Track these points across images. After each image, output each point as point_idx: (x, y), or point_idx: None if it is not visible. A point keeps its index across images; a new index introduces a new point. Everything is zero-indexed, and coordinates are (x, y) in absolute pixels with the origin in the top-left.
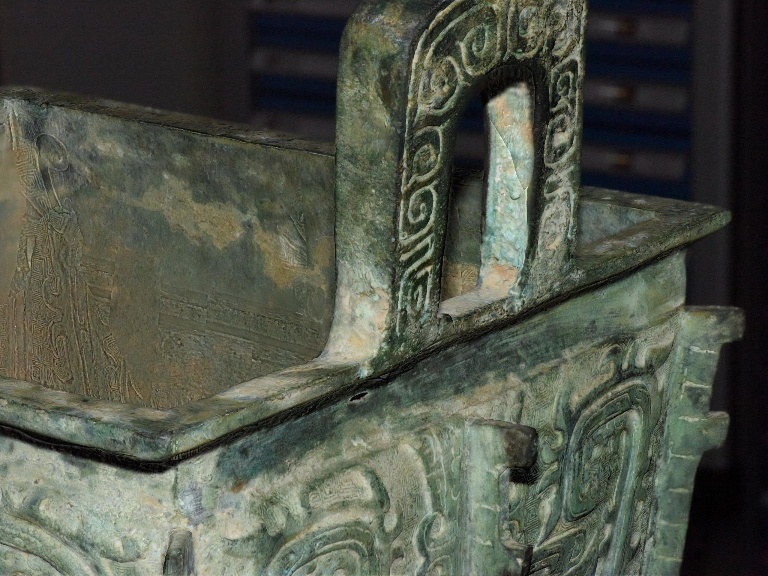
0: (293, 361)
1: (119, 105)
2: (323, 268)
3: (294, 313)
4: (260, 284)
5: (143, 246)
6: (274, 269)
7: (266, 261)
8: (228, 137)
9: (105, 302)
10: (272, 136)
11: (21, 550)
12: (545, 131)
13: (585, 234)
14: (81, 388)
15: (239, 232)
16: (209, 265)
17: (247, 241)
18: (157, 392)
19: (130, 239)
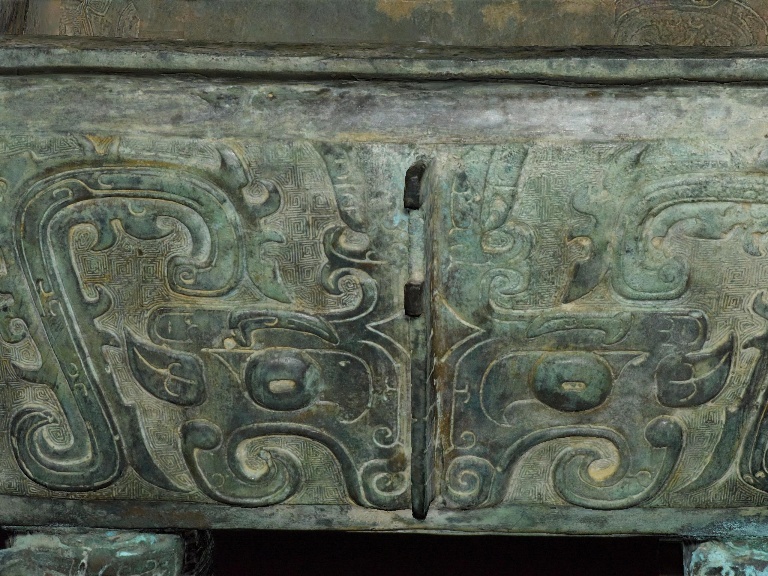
0: None
1: None
2: None
3: (416, 42)
4: (372, 22)
5: (220, 10)
6: (389, 5)
7: None
8: None
9: None
10: None
11: (750, 202)
12: None
13: None
14: None
15: None
16: (306, 14)
17: None
18: None
19: (202, 6)
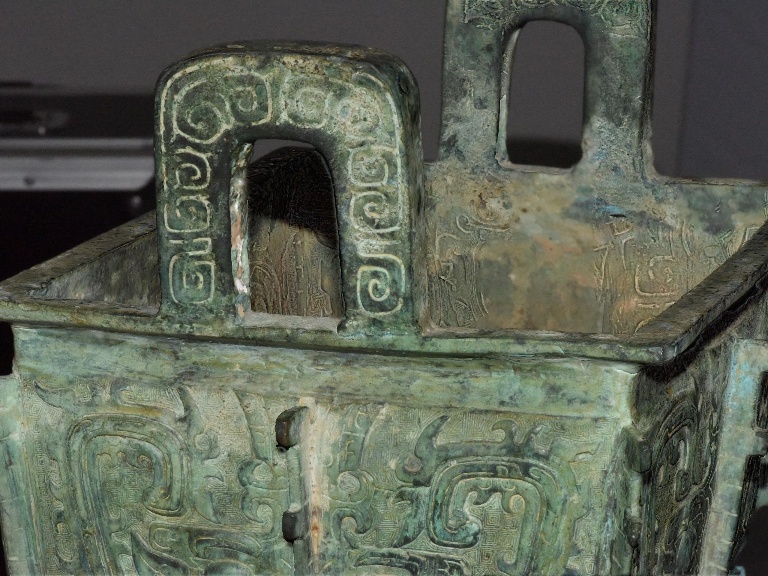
0: None
1: (45, 265)
2: None
3: None
4: None
5: None
6: None
7: None
8: None
9: None
10: (133, 227)
11: None
12: (505, 58)
13: None
14: None
15: None
16: None
17: None
18: None
19: None
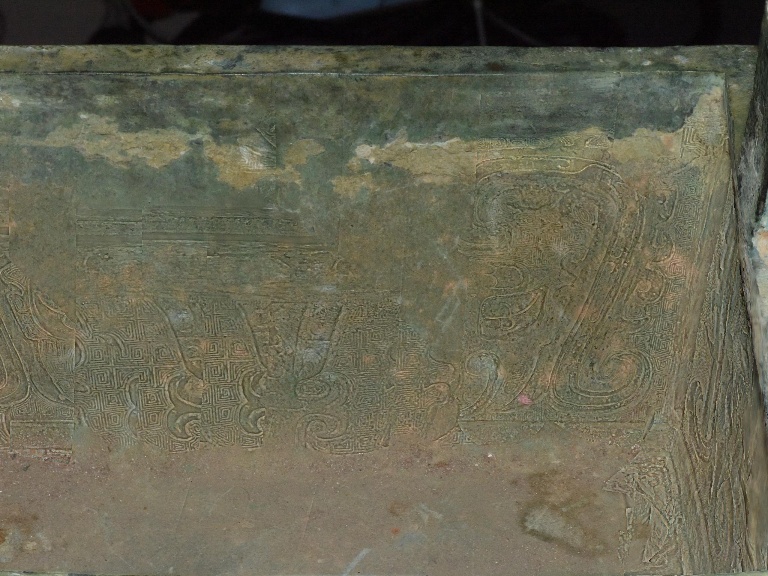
0: (262, 249)
1: None
2: (298, 166)
3: (261, 209)
4: (213, 191)
5: (47, 180)
6: (231, 175)
7: (221, 170)
8: (174, 72)
9: (1, 238)
10: (214, 56)
11: None
12: None
13: (630, 98)
14: None
15: (185, 151)
16: (142, 184)
17: (194, 156)
18: (83, 305)
19: (27, 176)
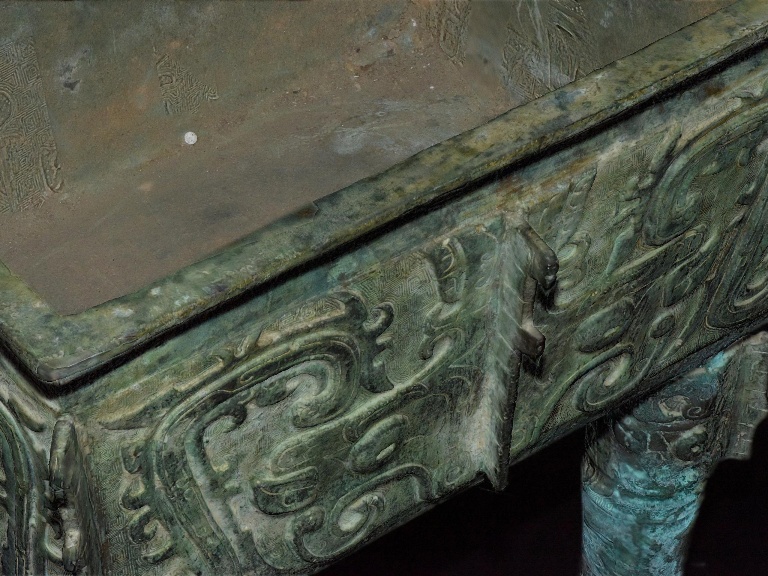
0: None
1: None
2: None
3: None
4: None
5: None
6: None
7: None
8: None
9: None
10: (588, 96)
11: None
12: None
13: None
14: (766, 236)
15: None
16: None
17: None
18: None
19: None
